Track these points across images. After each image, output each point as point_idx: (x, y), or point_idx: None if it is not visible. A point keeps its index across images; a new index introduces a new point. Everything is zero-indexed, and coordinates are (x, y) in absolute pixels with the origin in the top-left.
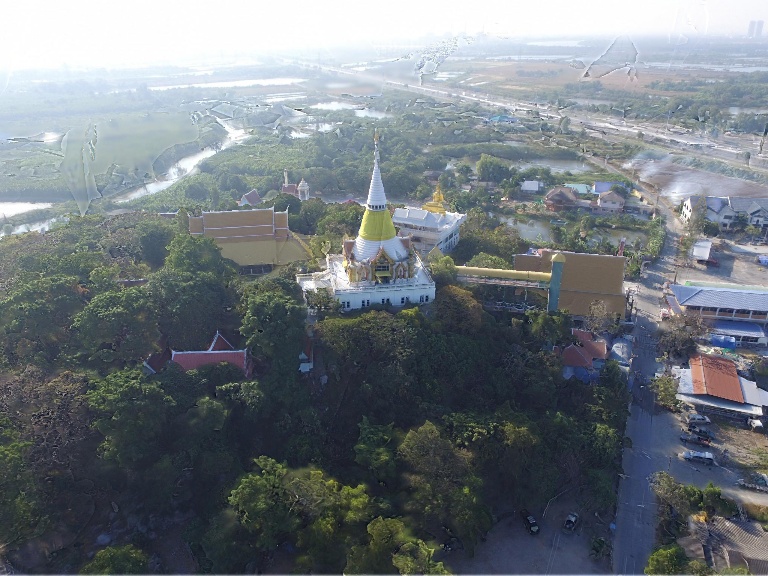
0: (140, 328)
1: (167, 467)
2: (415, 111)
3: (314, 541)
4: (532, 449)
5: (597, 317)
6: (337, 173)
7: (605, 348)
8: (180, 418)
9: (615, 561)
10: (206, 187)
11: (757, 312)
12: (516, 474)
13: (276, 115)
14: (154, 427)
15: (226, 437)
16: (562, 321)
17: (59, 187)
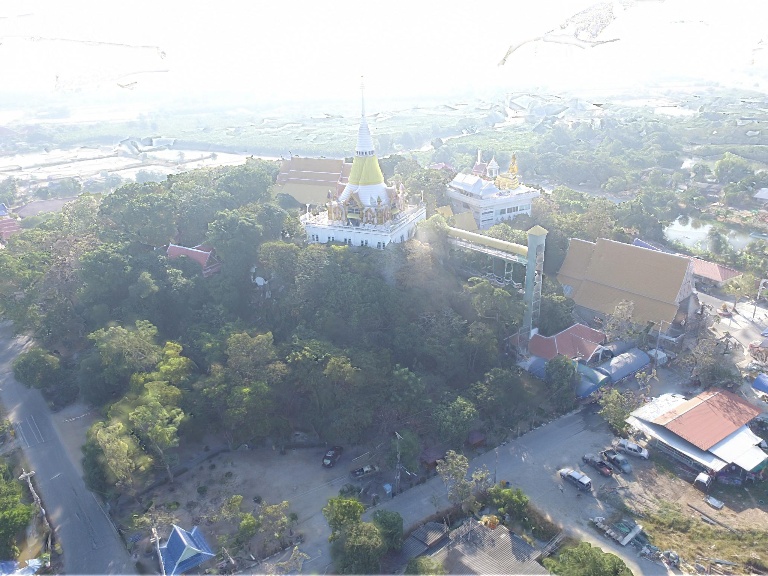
0: (159, 222)
1: (99, 311)
2: (731, 111)
3: None
4: (358, 390)
5: (613, 318)
6: (539, 158)
7: (594, 350)
8: (132, 285)
9: (364, 515)
10: (420, 160)
11: None
12: (321, 403)
13: (564, 107)
14: (112, 285)
15: (156, 308)
16: (546, 306)
17: (316, 149)
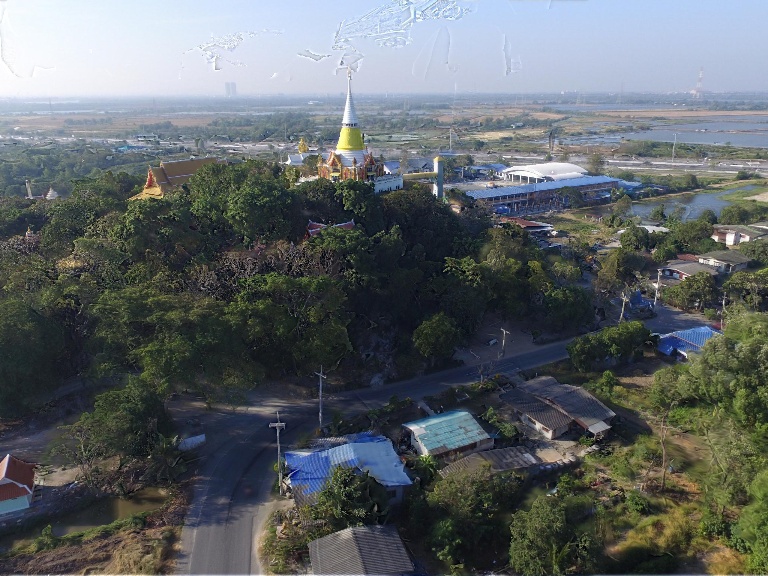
0: None
1: (405, 277)
2: None
3: (506, 288)
4: None
5: None
6: (69, 185)
7: None
8: None
9: None
10: None
11: (496, 198)
12: None
13: None
14: None
15: None
16: None
17: None
